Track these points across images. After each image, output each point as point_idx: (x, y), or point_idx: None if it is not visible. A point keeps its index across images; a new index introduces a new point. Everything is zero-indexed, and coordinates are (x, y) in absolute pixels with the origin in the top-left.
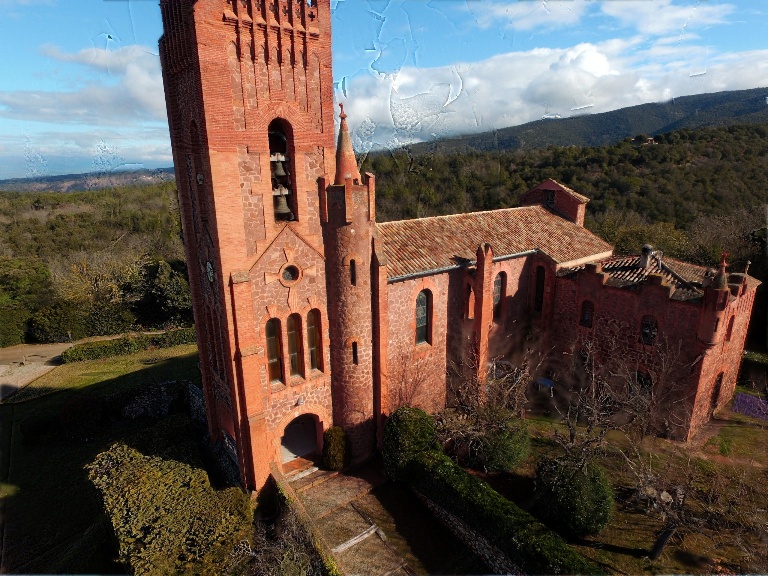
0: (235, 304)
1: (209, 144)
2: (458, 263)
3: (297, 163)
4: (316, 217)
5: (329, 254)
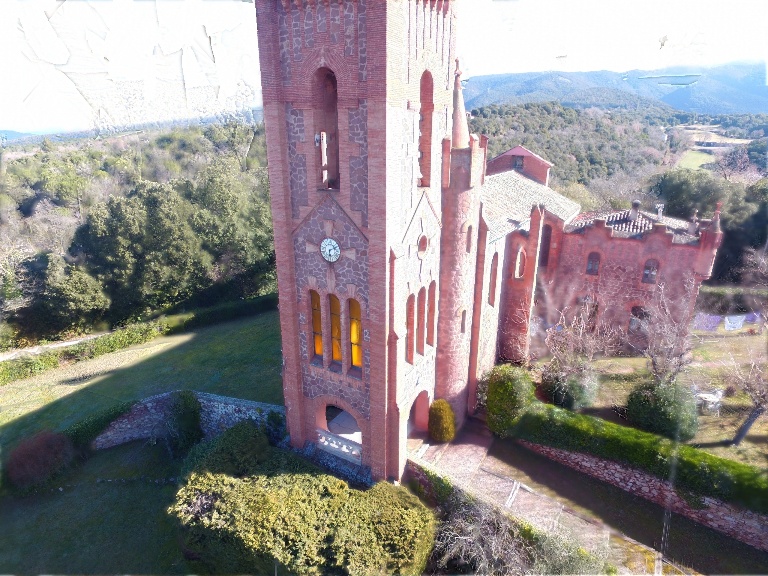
0: (394, 282)
1: (387, 97)
2: (515, 225)
3: (433, 123)
4: (439, 182)
5: (446, 221)
